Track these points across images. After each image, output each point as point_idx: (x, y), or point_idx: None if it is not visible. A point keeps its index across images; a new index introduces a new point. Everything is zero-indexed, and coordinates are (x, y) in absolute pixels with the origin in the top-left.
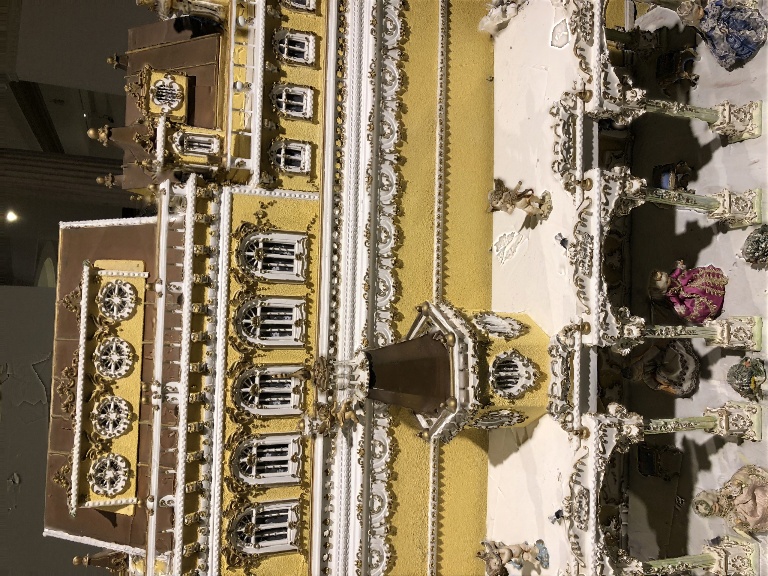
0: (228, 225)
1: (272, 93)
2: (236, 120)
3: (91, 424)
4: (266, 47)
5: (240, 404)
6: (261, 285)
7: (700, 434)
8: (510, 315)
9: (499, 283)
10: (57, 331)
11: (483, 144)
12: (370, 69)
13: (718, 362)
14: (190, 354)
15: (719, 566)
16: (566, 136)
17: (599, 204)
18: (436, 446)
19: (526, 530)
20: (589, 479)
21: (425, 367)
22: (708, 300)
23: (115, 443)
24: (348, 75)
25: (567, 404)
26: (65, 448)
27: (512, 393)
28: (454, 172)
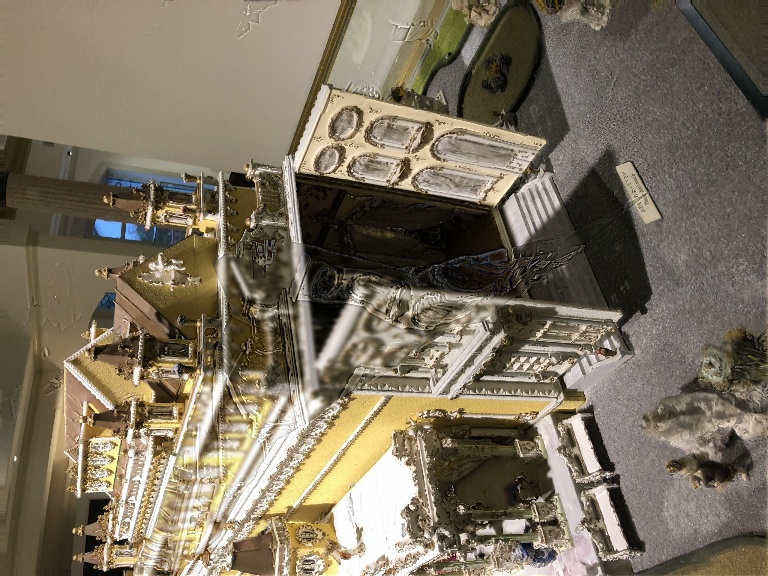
0: None
1: None
2: None
3: None
4: None
5: None
6: None
7: None
8: None
9: (342, 508)
10: (66, 399)
11: None
12: (289, 449)
13: None
14: None
15: None
16: None
17: None
18: None
19: None
20: None
21: None
22: None
23: None
24: None
25: None
26: None
27: None
28: (340, 465)
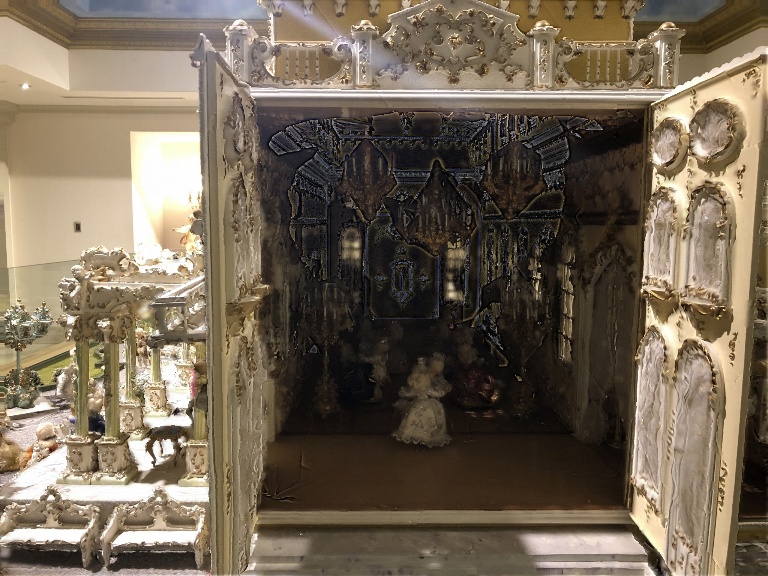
0: None
1: None
2: None
3: None
4: None
5: None
6: None
7: None
8: None
9: None
10: None
11: None
12: None
13: None
14: None
15: None
16: None
17: None
18: None
19: None
20: None
21: None
22: None
23: None
24: None
25: None
26: None
27: None
28: None
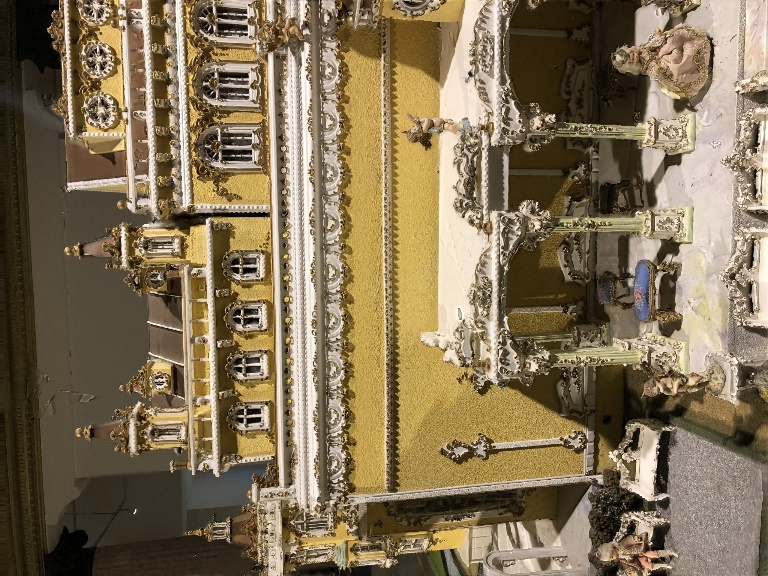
0: None
1: None
2: None
3: (81, 64)
4: None
5: (199, 31)
6: None
7: None
8: None
9: None
10: None
11: None
12: None
13: None
14: None
15: (648, 134)
16: None
17: None
18: (386, 72)
19: None
20: (494, 24)
21: None
22: None
23: (103, 83)
24: None
25: None
26: None
27: None
28: None
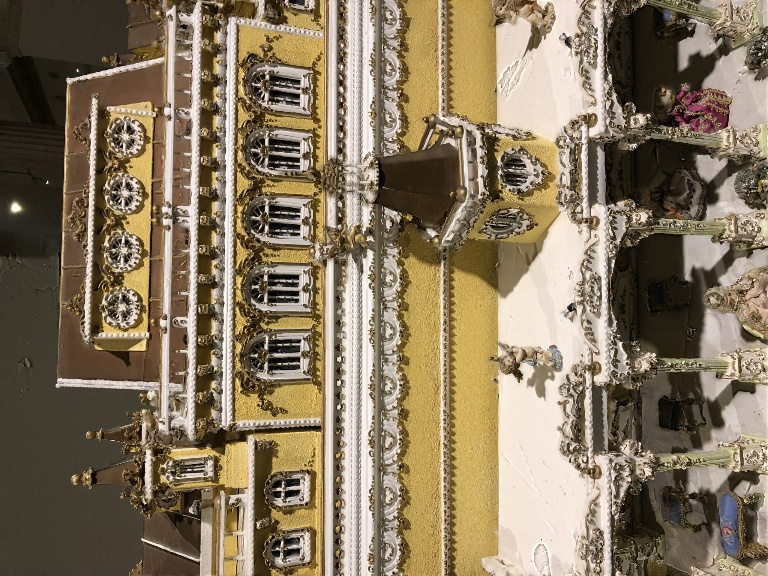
0: (234, 55)
1: None
2: None
3: (102, 257)
4: None
5: (250, 231)
6: (268, 117)
7: (709, 260)
8: None
9: (504, 117)
10: (66, 185)
11: None
12: None
13: (725, 182)
14: (200, 179)
15: (733, 368)
16: None
17: None
18: (446, 279)
19: (538, 343)
20: (600, 265)
21: (434, 168)
22: (713, 117)
23: (127, 277)
24: None
25: (576, 195)
26: None
27: (521, 189)
28: (457, 13)
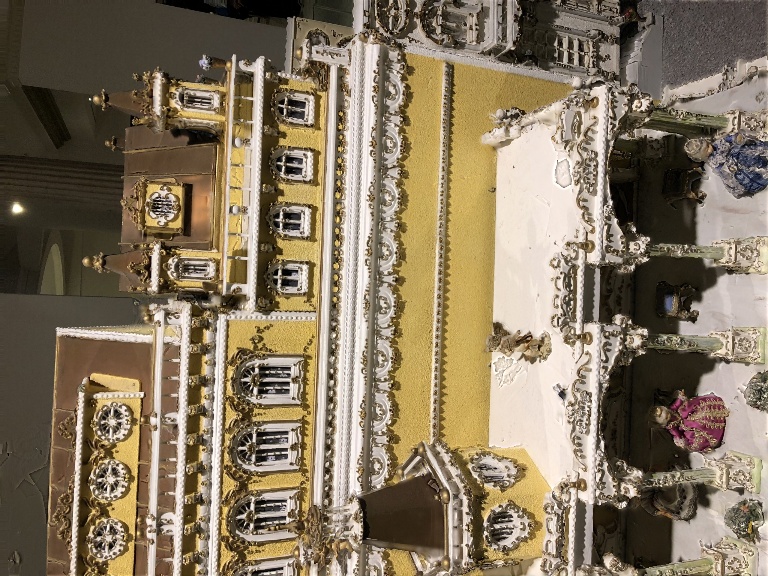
0: (223, 353)
1: (269, 214)
2: (233, 230)
3: (87, 547)
4: (263, 167)
5: (235, 532)
6: (257, 411)
7: None
8: (507, 452)
9: (497, 405)
10: (54, 439)
11: (484, 257)
12: (369, 192)
13: (716, 493)
14: (185, 485)
15: None
16: (566, 289)
17: (598, 362)
18: None
19: None
20: None
21: (419, 517)
22: (708, 435)
23: (111, 564)
24: (346, 196)
25: (561, 560)
26: (62, 558)
27: (506, 546)
28: (453, 288)
